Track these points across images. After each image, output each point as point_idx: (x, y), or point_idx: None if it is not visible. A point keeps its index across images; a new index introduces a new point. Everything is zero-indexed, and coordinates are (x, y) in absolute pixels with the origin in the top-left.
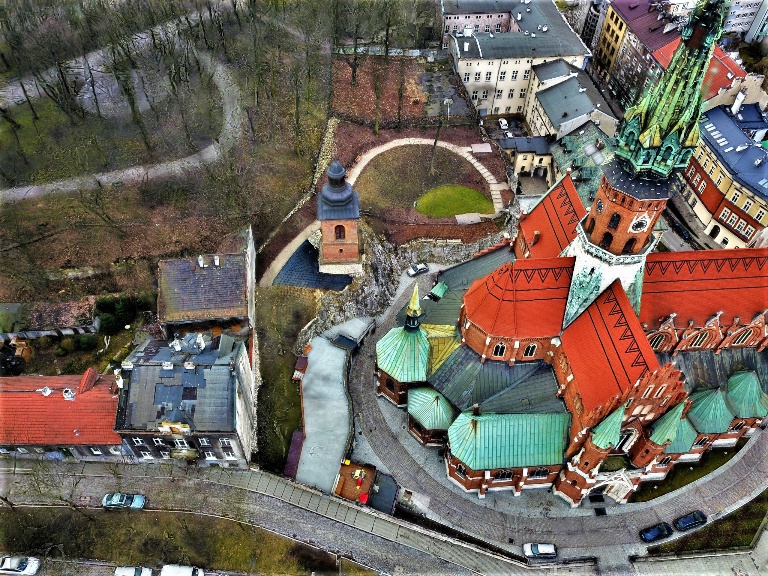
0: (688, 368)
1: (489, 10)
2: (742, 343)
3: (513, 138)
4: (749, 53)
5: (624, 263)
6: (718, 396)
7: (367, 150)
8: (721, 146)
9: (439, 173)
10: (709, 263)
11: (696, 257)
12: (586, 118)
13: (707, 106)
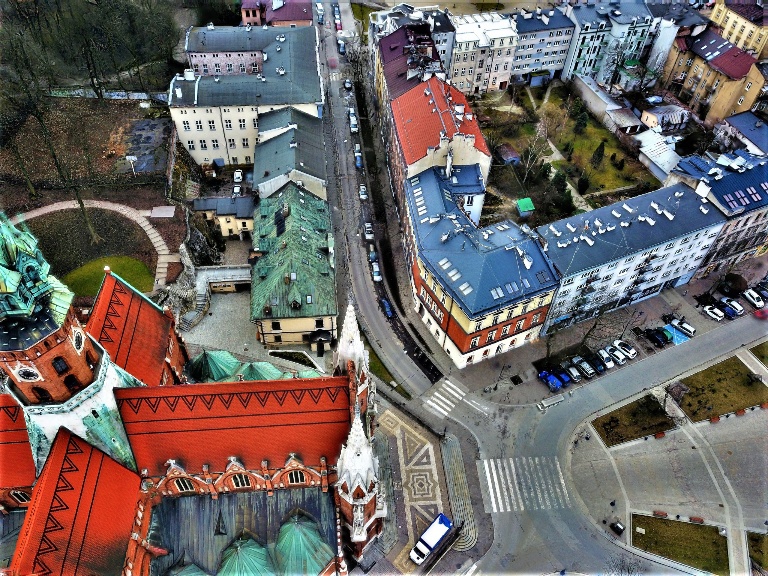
0: (231, 514)
1: (238, 48)
2: (303, 482)
3: (216, 198)
4: (560, 93)
5: (45, 413)
6: (240, 557)
7: (12, 216)
8: (419, 215)
9: (105, 241)
10: (212, 398)
11: (193, 392)
12: (285, 179)
13: (419, 167)
